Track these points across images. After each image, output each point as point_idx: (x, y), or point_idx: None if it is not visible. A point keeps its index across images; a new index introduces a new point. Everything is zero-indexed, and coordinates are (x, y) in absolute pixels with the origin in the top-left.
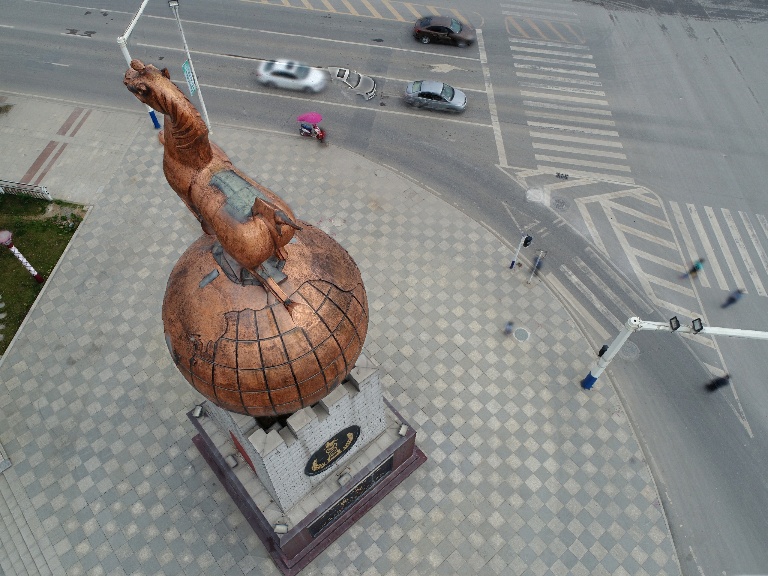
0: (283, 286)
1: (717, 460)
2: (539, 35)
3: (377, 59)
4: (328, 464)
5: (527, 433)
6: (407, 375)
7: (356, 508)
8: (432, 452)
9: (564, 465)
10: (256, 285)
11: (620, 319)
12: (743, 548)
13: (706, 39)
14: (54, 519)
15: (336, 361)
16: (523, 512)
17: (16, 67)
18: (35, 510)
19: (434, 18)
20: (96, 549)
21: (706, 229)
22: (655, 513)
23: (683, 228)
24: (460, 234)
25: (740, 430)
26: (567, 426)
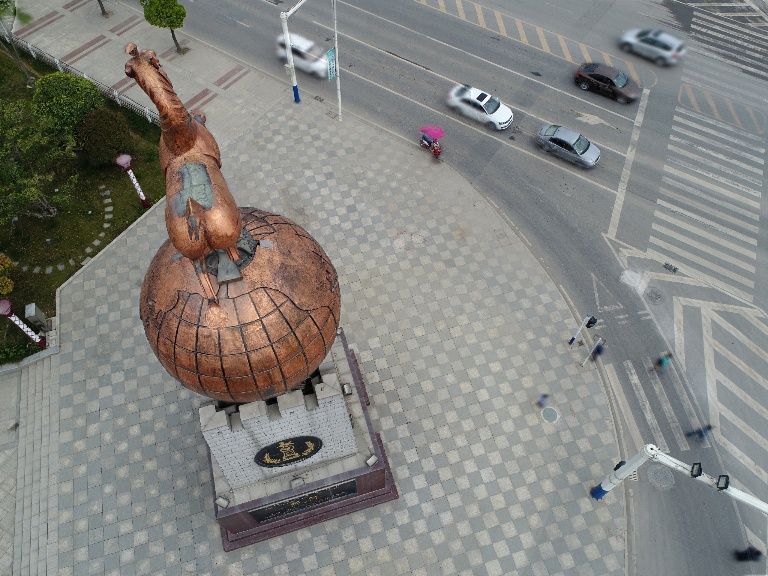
0: (237, 284)
1: None
2: (712, 112)
3: (527, 92)
4: (284, 462)
5: (510, 516)
6: (417, 409)
7: (311, 514)
8: (407, 493)
9: (534, 565)
10: (213, 275)
11: (667, 440)
12: None
13: None
14: (70, 411)
15: (271, 371)
16: None
17: (207, 17)
18: (60, 397)
19: (601, 66)
20: (89, 450)
21: None
22: None
23: None
24: (532, 291)
25: None
26: (556, 527)
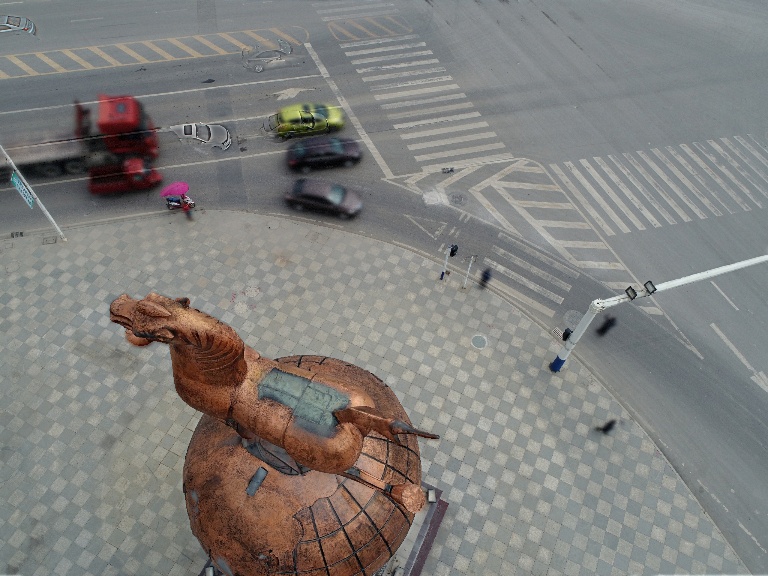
0: None
1: (686, 391)
2: (367, 34)
3: (216, 102)
4: (381, 571)
5: (525, 437)
6: None
7: None
8: (449, 495)
9: (569, 453)
10: None
11: (556, 292)
12: (737, 461)
13: (516, 0)
14: None
15: None
16: (554, 515)
17: None
18: None
19: (260, 44)
20: None
21: (589, 181)
22: (660, 463)
23: (571, 187)
24: (380, 262)
25: (691, 356)
26: (556, 414)
